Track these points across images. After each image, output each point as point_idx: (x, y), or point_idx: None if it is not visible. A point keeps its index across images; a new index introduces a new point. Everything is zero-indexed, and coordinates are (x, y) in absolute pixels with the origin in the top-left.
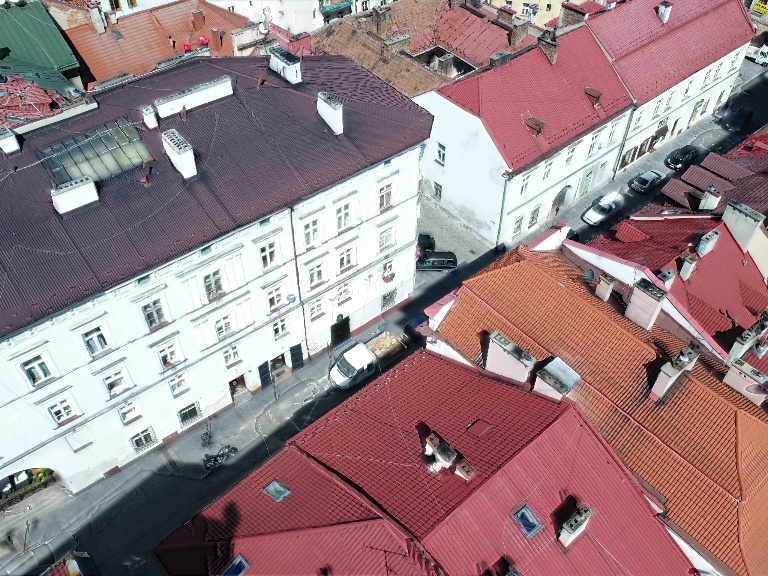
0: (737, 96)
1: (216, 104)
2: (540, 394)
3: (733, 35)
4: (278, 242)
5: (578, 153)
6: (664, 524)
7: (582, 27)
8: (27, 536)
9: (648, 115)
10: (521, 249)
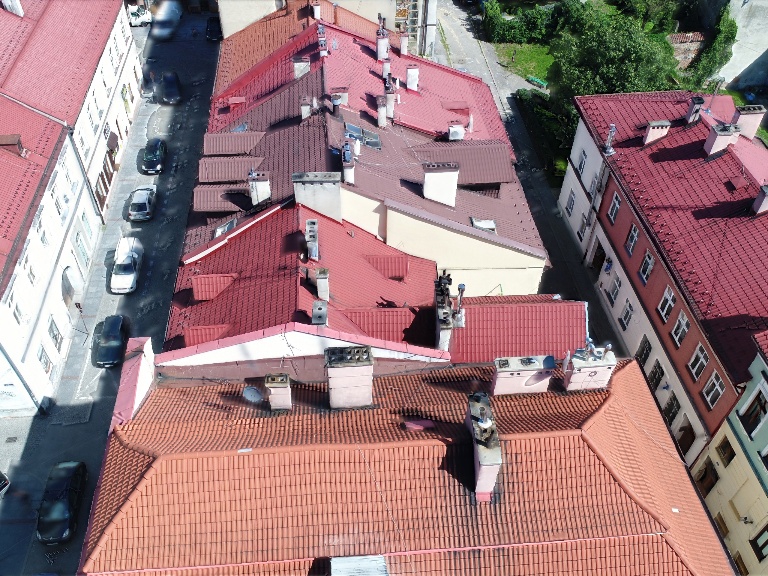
0: (146, 67)
1: None
2: None
3: (103, 2)
4: None
5: (48, 224)
6: None
7: None
8: None
9: (88, 132)
10: (123, 433)
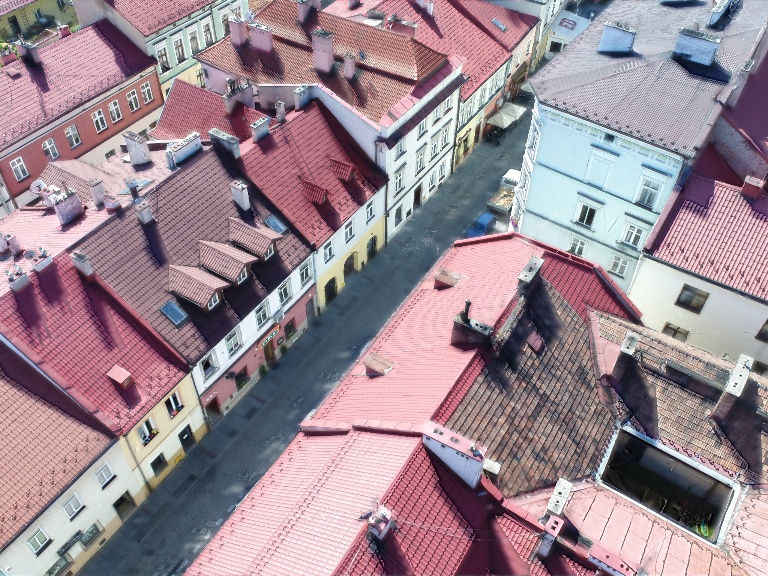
0: None
1: None
2: None
3: None
4: None
5: None
6: None
7: None
8: None
9: None
10: (416, 75)
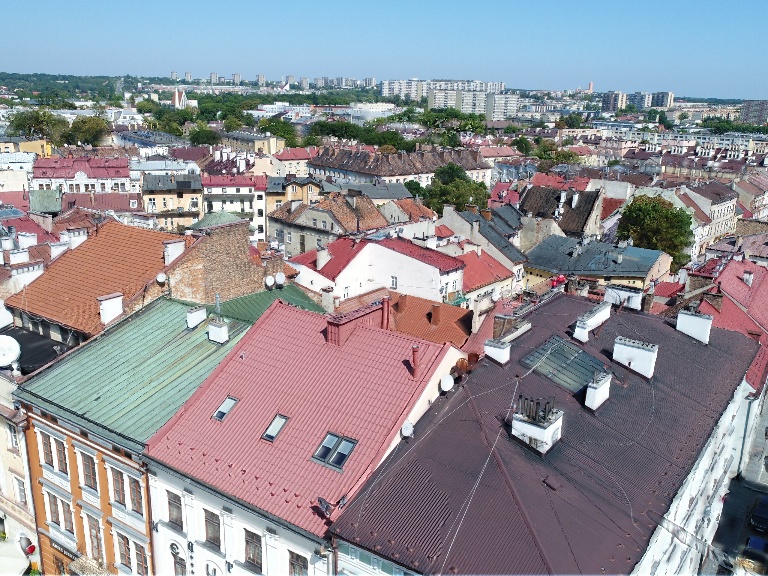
0: None
1: (603, 325)
2: None
3: None
4: (712, 442)
5: None
6: None
7: (715, 287)
8: None
9: None
10: None
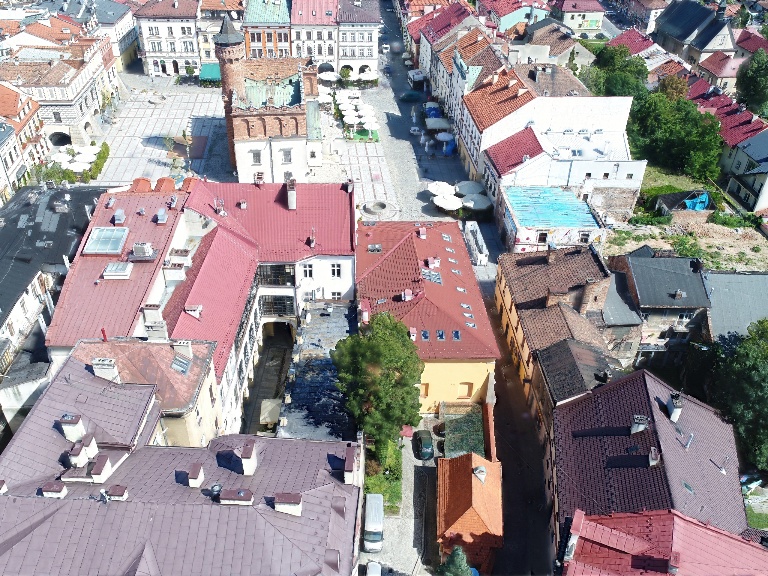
0: None
1: None
2: None
3: None
4: None
5: None
6: None
7: None
8: (380, 78)
9: None
10: None
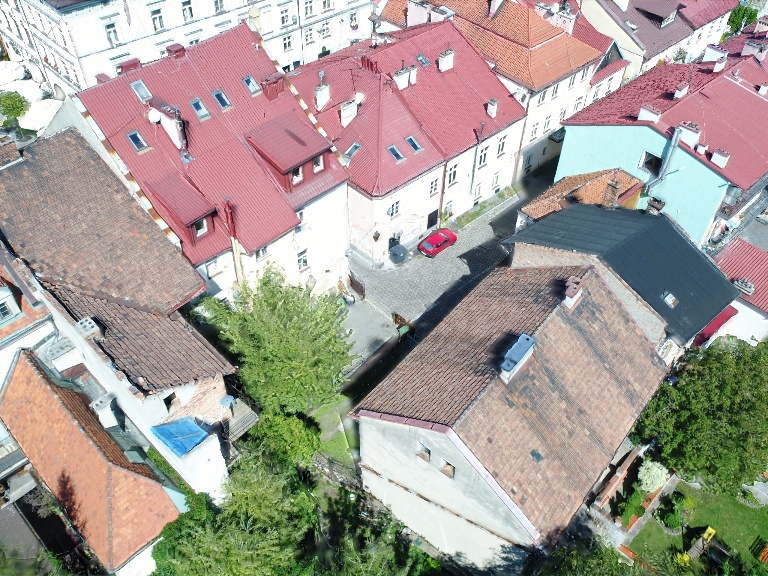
0: None
1: None
2: (434, 23)
3: None
4: None
5: None
6: (495, 73)
7: None
8: None
9: None
10: None
